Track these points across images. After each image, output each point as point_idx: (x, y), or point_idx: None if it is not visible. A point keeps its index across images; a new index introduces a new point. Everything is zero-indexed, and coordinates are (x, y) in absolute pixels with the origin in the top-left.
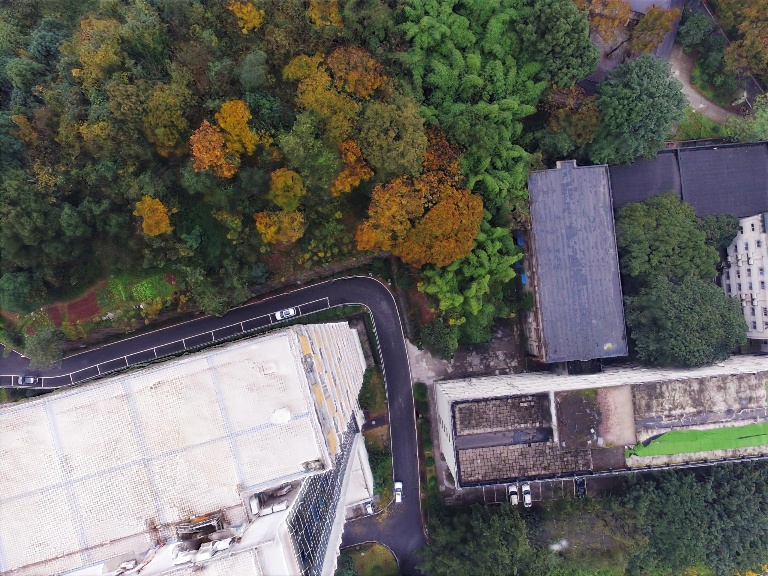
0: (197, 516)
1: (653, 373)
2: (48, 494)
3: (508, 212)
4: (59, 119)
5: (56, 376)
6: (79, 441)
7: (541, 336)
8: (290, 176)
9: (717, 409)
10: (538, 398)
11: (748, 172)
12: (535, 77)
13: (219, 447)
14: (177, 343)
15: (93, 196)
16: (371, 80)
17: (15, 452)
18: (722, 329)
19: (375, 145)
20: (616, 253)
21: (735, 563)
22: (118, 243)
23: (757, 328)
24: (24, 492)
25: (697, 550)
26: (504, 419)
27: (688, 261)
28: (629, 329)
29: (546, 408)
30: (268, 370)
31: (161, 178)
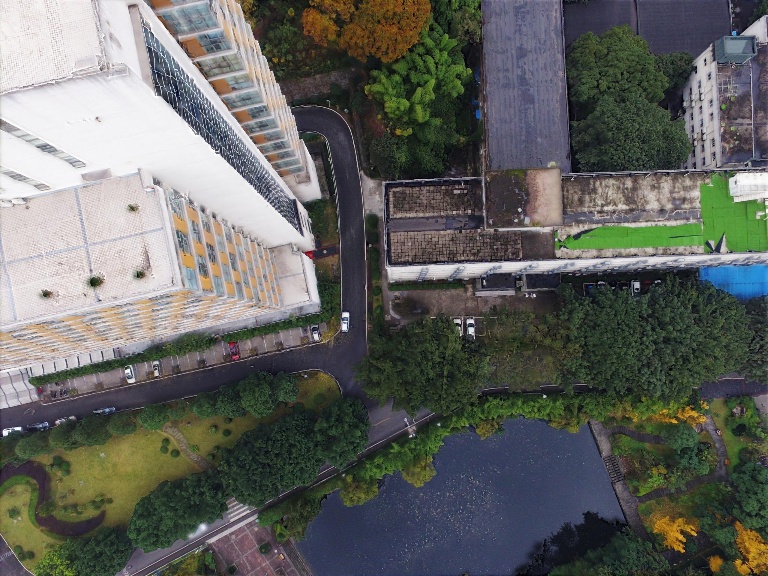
0: None
1: None
2: None
3: None
4: None
5: None
6: None
7: None
8: None
9: (650, 208)
10: (471, 186)
11: (706, 15)
12: None
13: None
14: None
15: None
16: None
17: None
18: (664, 144)
19: None
20: (565, 75)
21: (667, 380)
22: None
23: (706, 163)
24: None
25: (627, 358)
26: (437, 205)
27: (636, 85)
28: (574, 151)
29: (479, 196)
30: None
31: None
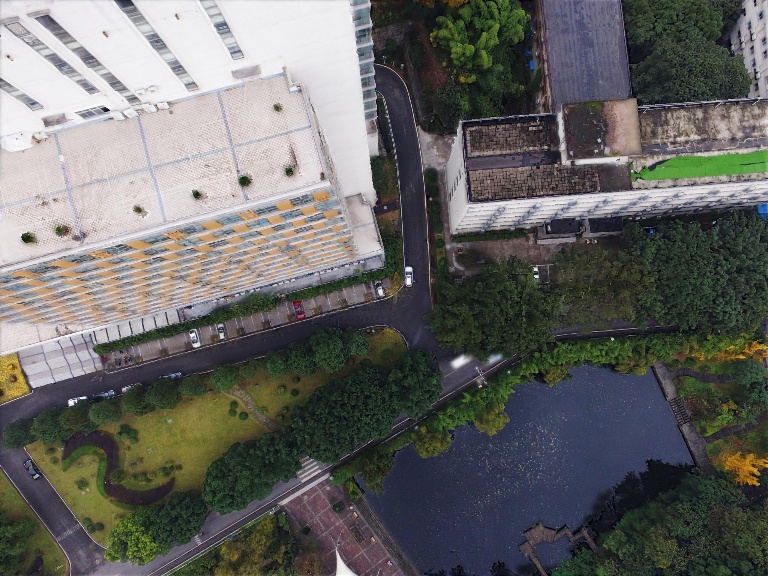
0: None
1: None
2: None
3: None
4: None
5: None
6: None
7: (549, 103)
8: None
9: (721, 137)
10: (546, 123)
11: None
12: None
13: None
14: None
15: None
16: None
17: None
18: None
19: None
20: (622, 18)
21: (741, 309)
22: None
23: None
24: None
25: (703, 288)
26: (513, 142)
27: (692, 26)
28: (635, 92)
29: (554, 132)
30: None
31: None
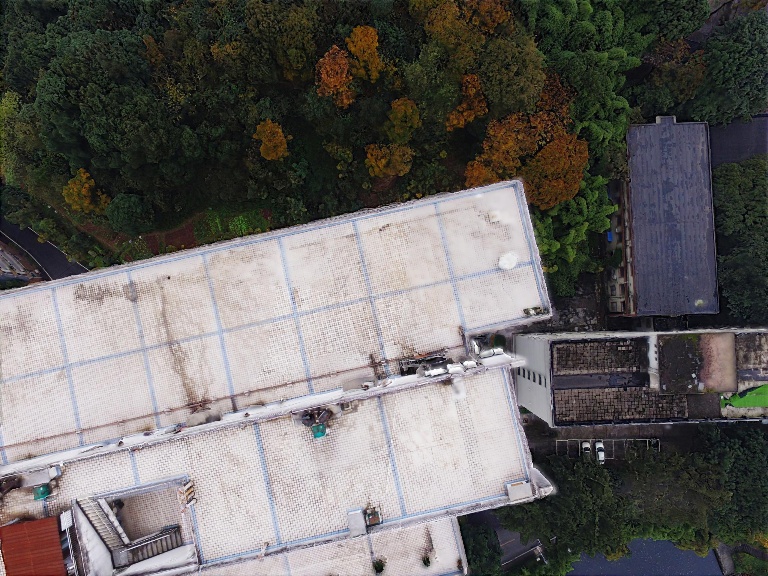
0: (420, 354)
1: (747, 330)
2: (279, 324)
3: (608, 162)
4: (183, 43)
5: None
6: (310, 276)
7: (629, 291)
8: (411, 105)
9: None
10: (636, 343)
11: None
12: (642, 30)
13: (444, 290)
14: None
15: (210, 121)
16: (499, 12)
17: (249, 283)
18: None
19: (495, 80)
20: (712, 210)
21: None
22: (223, 173)
23: None
24: (257, 321)
25: None
26: (601, 362)
27: None
28: (720, 287)
29: (644, 353)
30: (494, 218)
31: (278, 105)
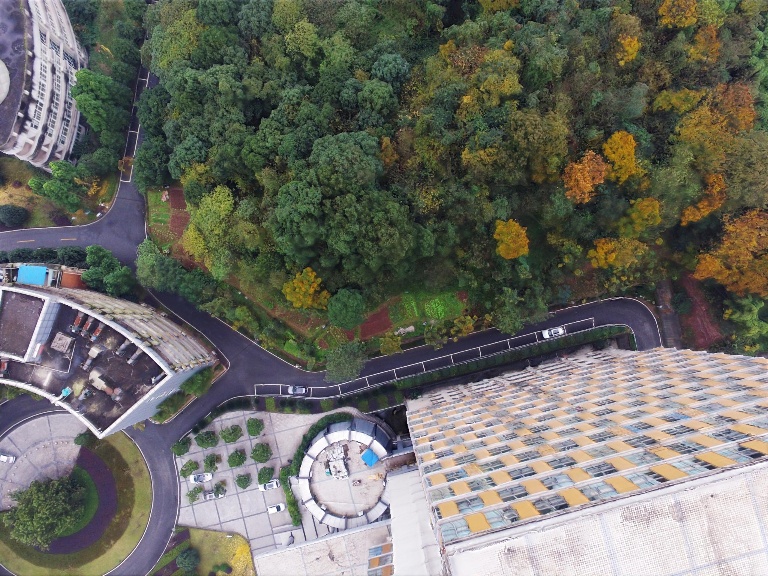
0: None
1: None
2: None
3: None
4: (413, 141)
5: (325, 387)
6: None
7: None
8: None
9: None
10: None
11: None
12: None
13: None
14: (446, 358)
15: (438, 217)
16: None
17: None
18: None
19: (737, 178)
20: None
21: None
22: None
23: None
24: None
25: None
26: None
27: None
28: None
29: None
30: None
31: (509, 202)
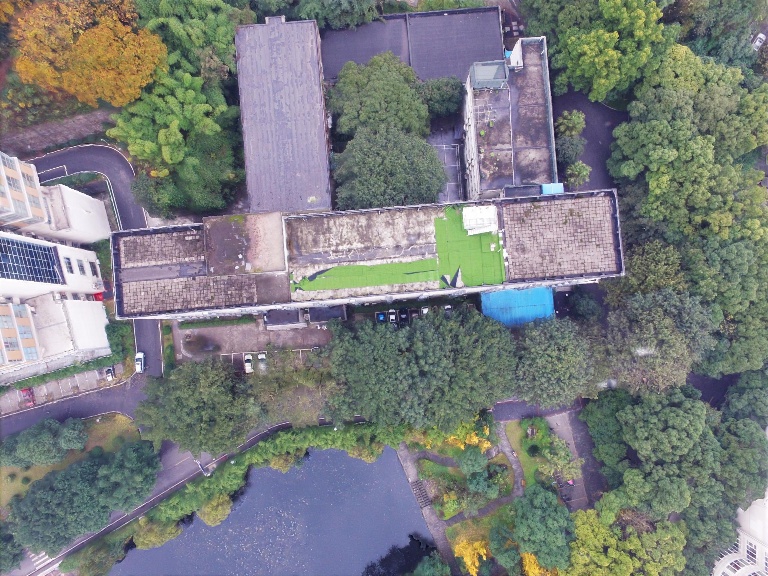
0: None
1: None
2: None
3: None
4: None
5: None
6: None
7: None
8: None
9: (385, 245)
10: None
11: (478, 37)
12: None
13: None
14: None
15: None
16: None
17: None
18: (413, 176)
19: None
20: (322, 107)
21: (429, 412)
22: None
23: None
24: None
25: (381, 395)
26: (169, 252)
27: (393, 115)
28: (337, 184)
29: None
30: None
31: None
